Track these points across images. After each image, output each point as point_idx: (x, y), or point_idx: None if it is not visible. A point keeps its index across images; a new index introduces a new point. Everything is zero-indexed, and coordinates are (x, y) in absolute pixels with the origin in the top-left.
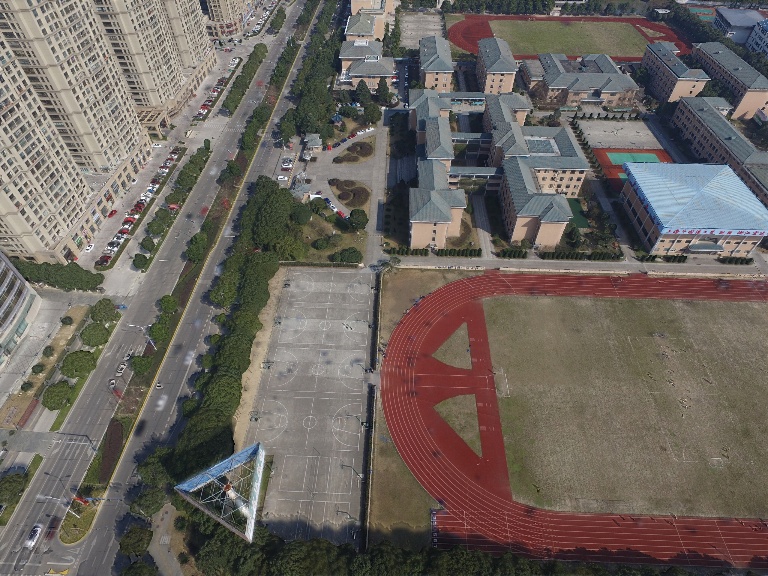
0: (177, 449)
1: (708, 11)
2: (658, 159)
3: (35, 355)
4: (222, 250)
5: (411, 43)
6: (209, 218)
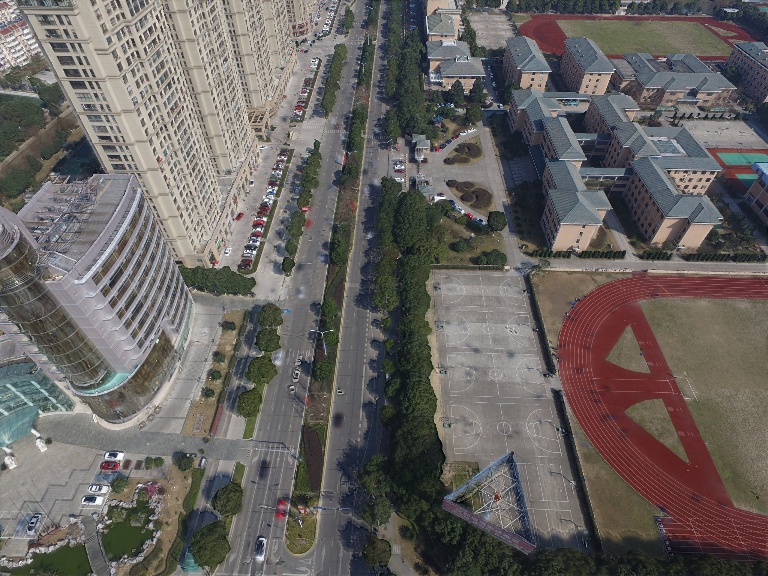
0: (397, 457)
1: None
2: None
3: (205, 361)
4: (360, 253)
5: (485, 43)
6: (337, 220)
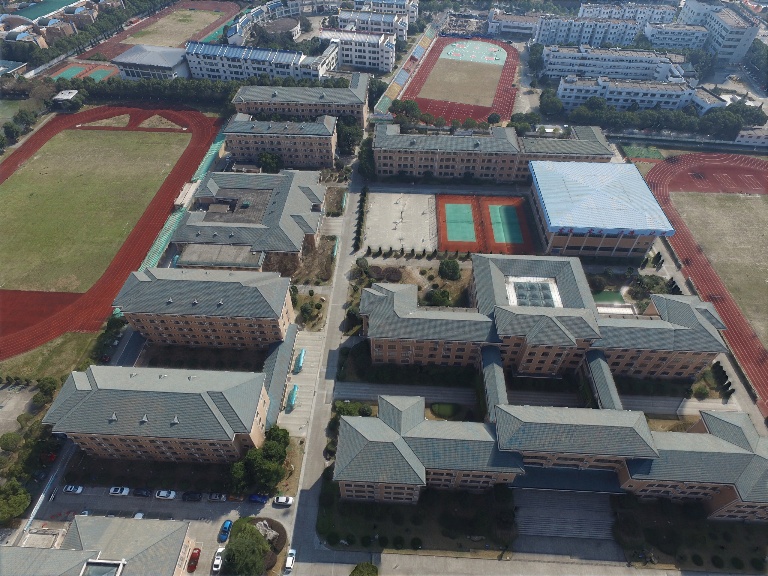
0: None
1: (76, 69)
2: (457, 204)
3: None
4: None
5: None
6: None
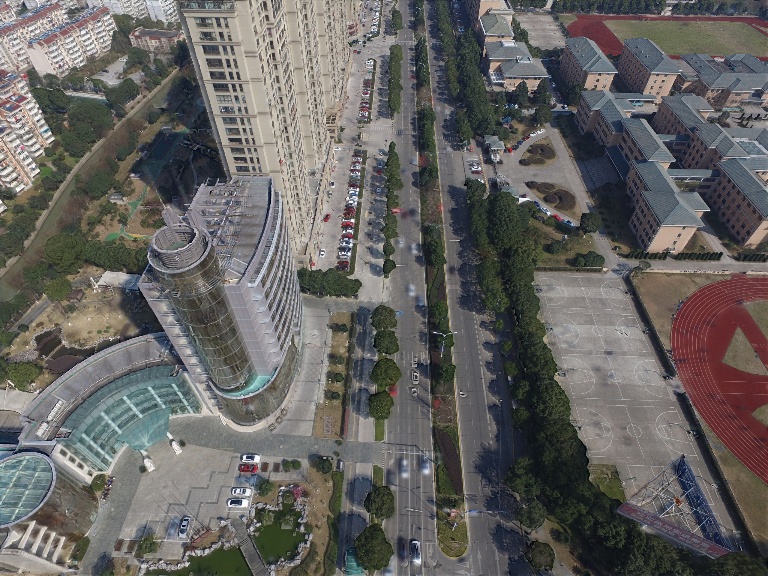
0: (545, 460)
1: None
2: None
3: (321, 363)
4: (454, 255)
5: (536, 44)
6: (425, 222)
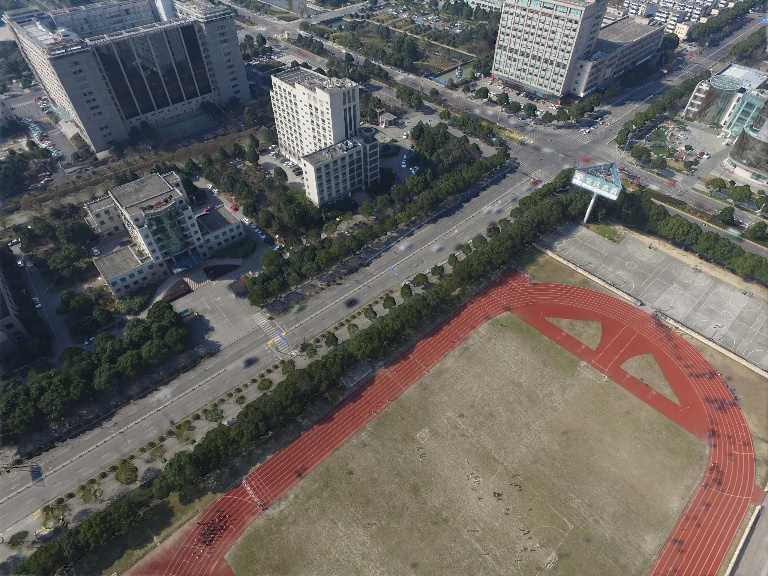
0: None
1: None
2: None
3: None
4: None
5: None
6: None
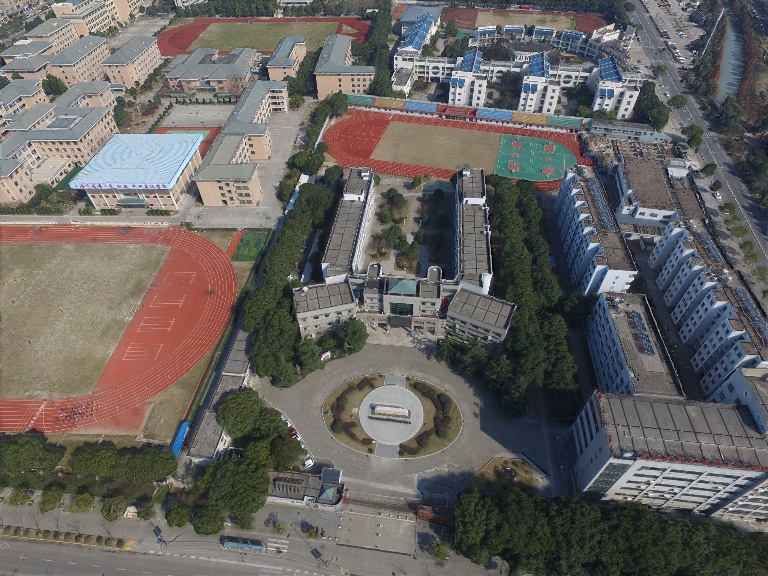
0: None
1: None
2: (207, 135)
3: None
4: None
5: (116, 44)
6: None
